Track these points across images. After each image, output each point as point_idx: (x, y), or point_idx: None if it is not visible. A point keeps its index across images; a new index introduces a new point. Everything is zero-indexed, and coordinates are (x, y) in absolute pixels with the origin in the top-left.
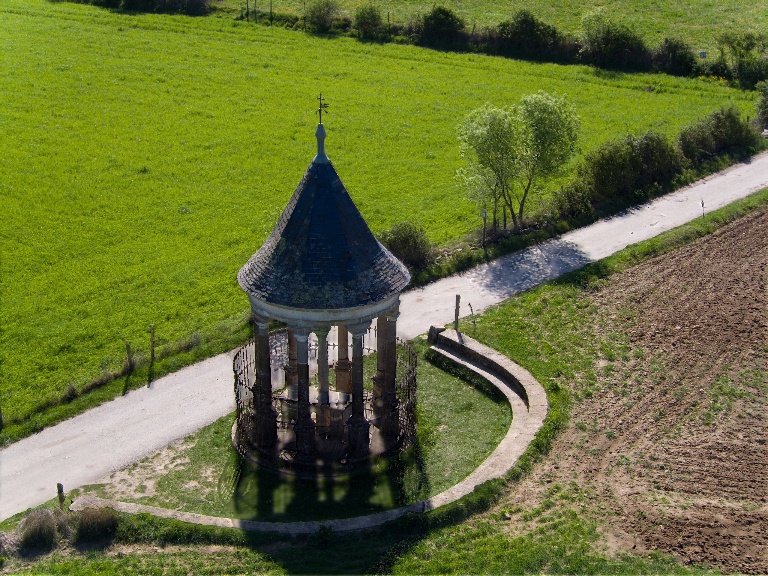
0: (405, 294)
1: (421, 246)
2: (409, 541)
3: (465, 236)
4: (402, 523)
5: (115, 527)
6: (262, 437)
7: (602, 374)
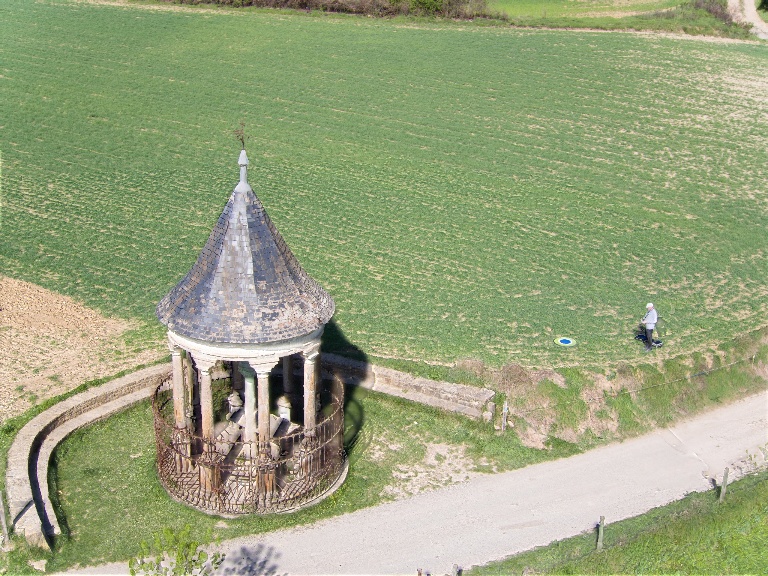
0: None
1: None
2: None
3: None
4: None
5: None
6: None
7: None
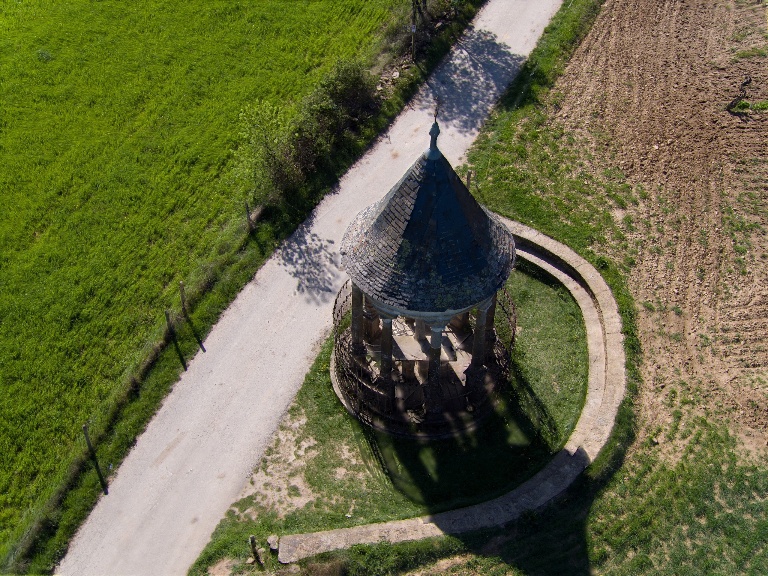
0: (376, 150)
1: (369, 87)
2: (598, 499)
3: (378, 42)
4: (587, 484)
5: (346, 574)
6: (385, 404)
7: (627, 230)
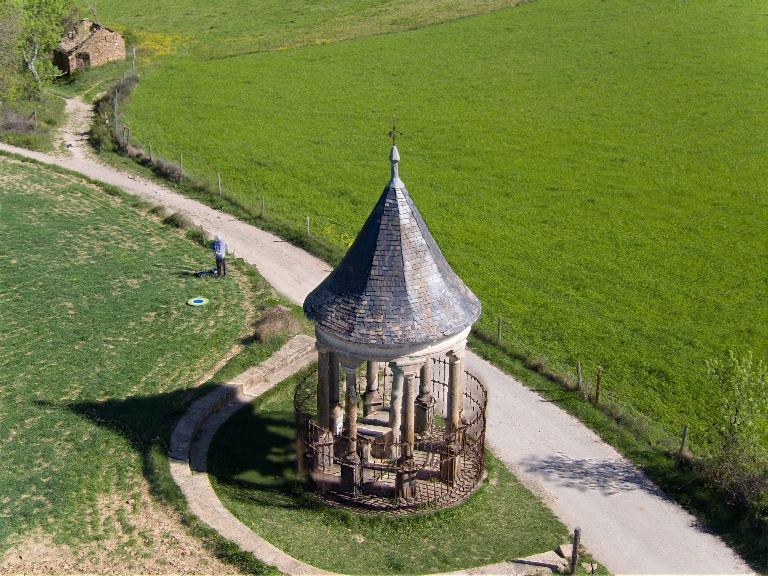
0: None
1: None
2: None
3: None
4: None
5: None
6: None
7: None
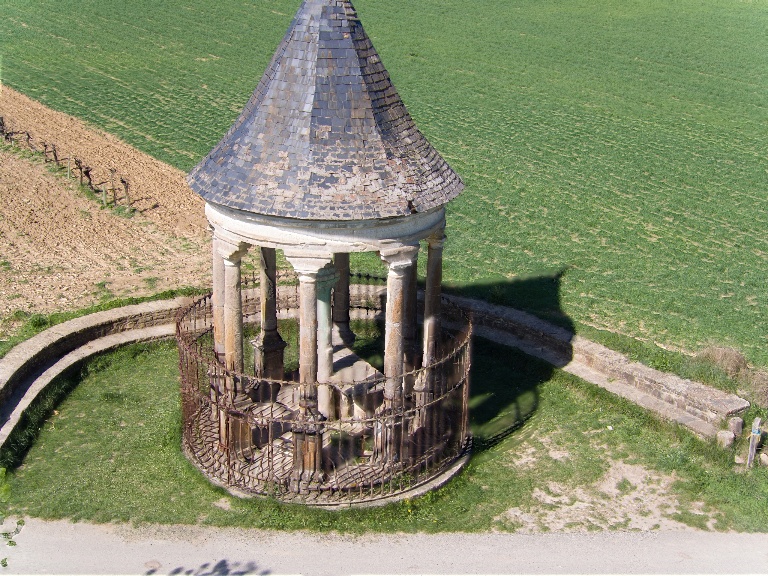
0: None
1: None
2: None
3: None
4: None
5: None
6: None
7: None
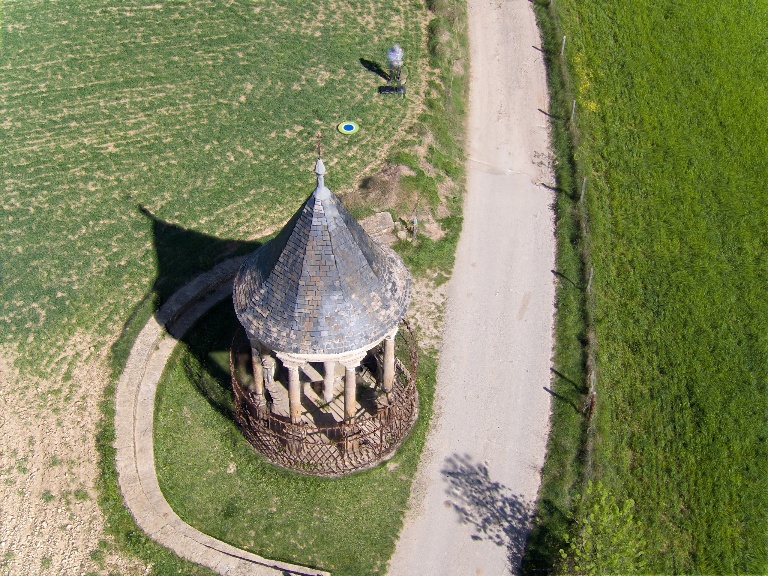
0: None
1: None
2: None
3: None
4: (158, 292)
5: None
6: None
7: None
